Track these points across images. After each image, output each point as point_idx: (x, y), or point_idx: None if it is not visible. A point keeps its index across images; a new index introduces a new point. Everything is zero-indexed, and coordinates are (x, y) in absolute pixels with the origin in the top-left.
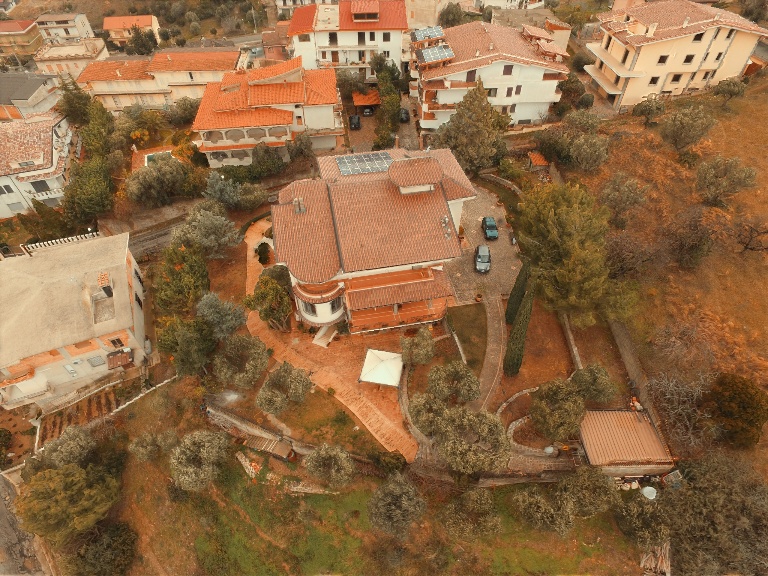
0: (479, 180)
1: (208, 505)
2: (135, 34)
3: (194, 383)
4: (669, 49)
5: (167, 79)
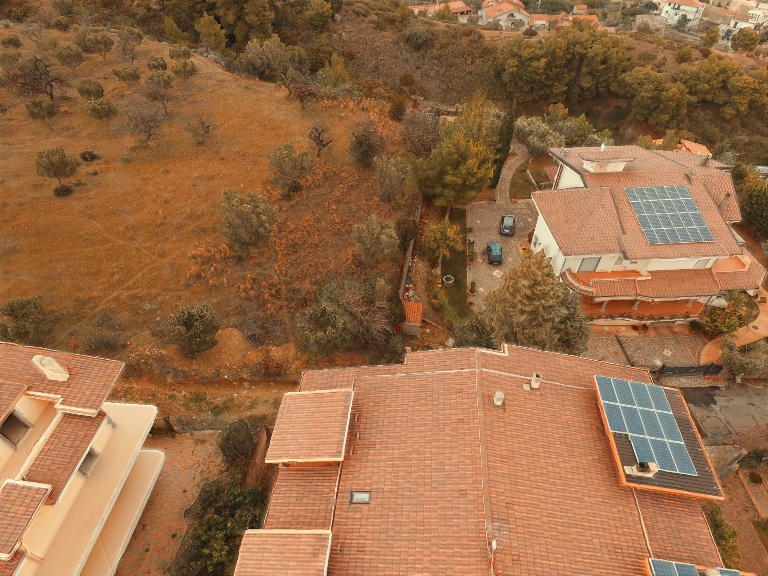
0: None
1: None
2: None
3: None
4: None
5: None
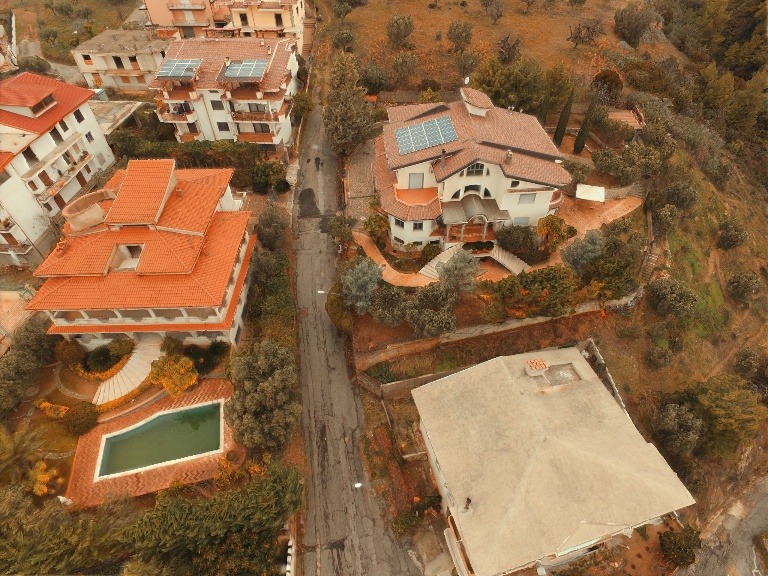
0: None
1: (683, 318)
2: None
3: (602, 320)
4: None
5: None
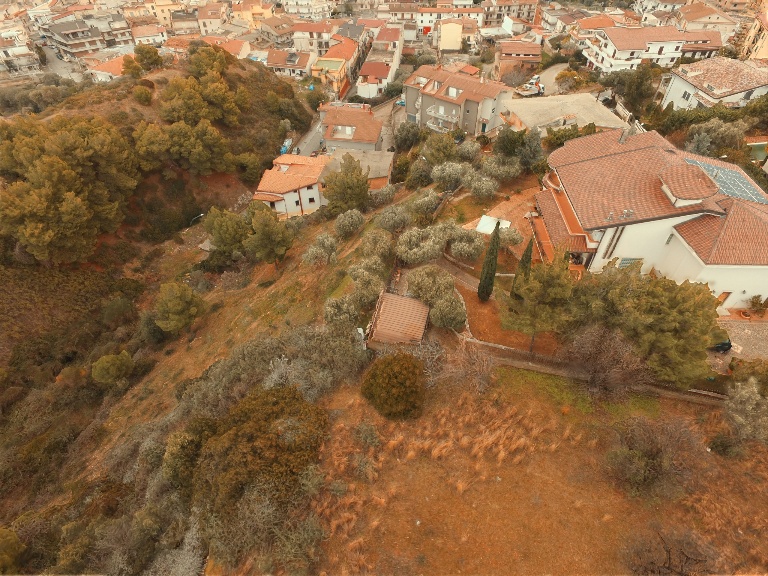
0: None
1: None
2: None
3: None
4: None
5: None
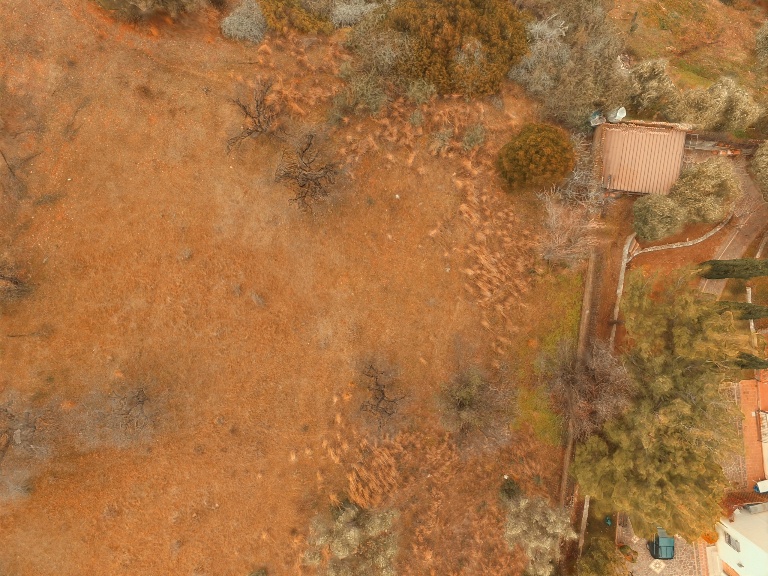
0: None
1: None
2: None
3: None
4: None
5: None
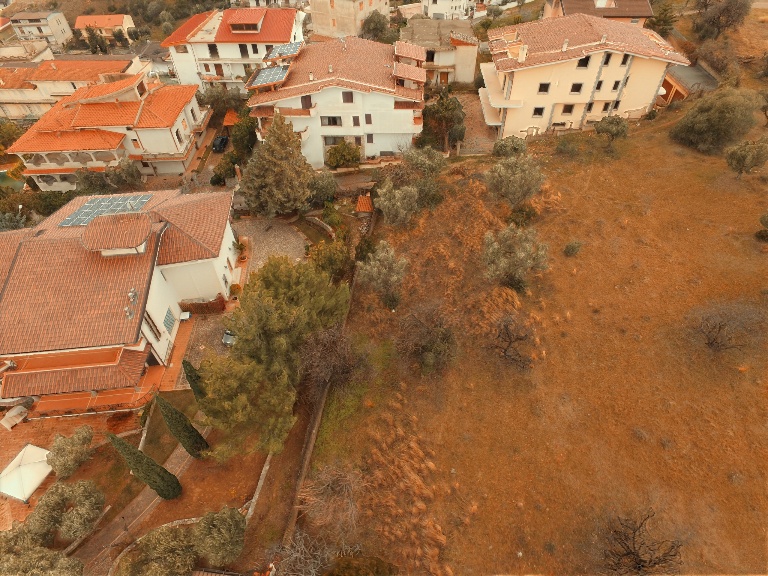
0: (303, 223)
1: None
2: (90, 35)
3: None
4: (548, 76)
5: (49, 89)
